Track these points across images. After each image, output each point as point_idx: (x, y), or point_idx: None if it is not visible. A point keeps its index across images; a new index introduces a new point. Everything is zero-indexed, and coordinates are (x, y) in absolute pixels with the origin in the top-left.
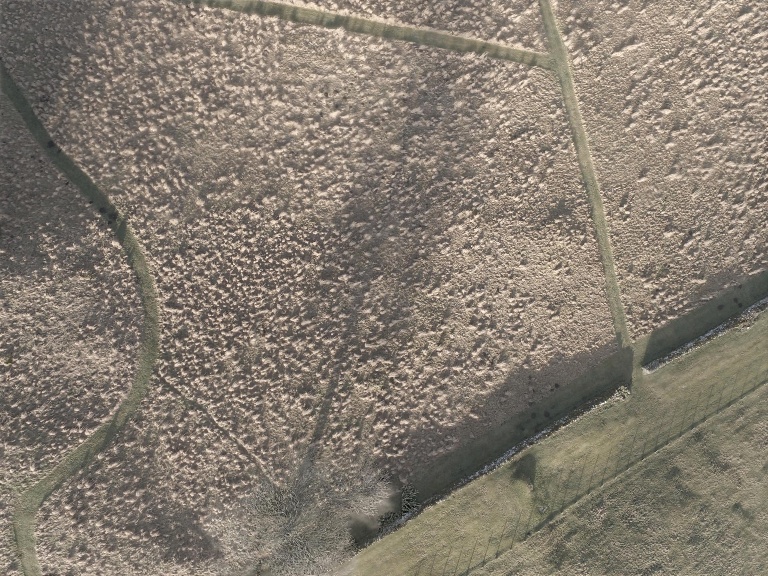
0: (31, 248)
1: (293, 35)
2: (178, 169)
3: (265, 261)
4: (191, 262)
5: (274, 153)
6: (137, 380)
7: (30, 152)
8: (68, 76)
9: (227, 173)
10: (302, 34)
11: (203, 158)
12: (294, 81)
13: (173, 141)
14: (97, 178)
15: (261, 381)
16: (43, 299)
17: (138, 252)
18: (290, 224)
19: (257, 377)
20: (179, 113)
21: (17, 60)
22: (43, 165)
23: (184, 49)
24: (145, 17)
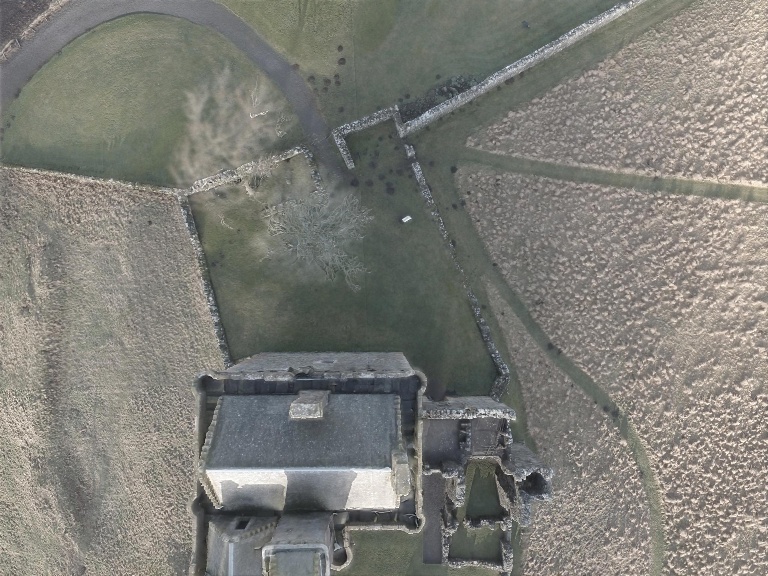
0: (561, 458)
1: (754, 216)
2: (664, 359)
3: (748, 442)
4: (685, 451)
5: (745, 334)
6: (651, 575)
7: (536, 357)
8: (558, 276)
9: (705, 358)
10: (762, 214)
11: (683, 345)
12: (758, 261)
13: (657, 332)
14: (597, 377)
15: (760, 564)
16: (576, 508)
17: (639, 447)
18: (767, 404)
19: (756, 560)
20: (659, 303)
21: (511, 265)
22: (550, 370)
23: (655, 238)
24: (617, 209)
